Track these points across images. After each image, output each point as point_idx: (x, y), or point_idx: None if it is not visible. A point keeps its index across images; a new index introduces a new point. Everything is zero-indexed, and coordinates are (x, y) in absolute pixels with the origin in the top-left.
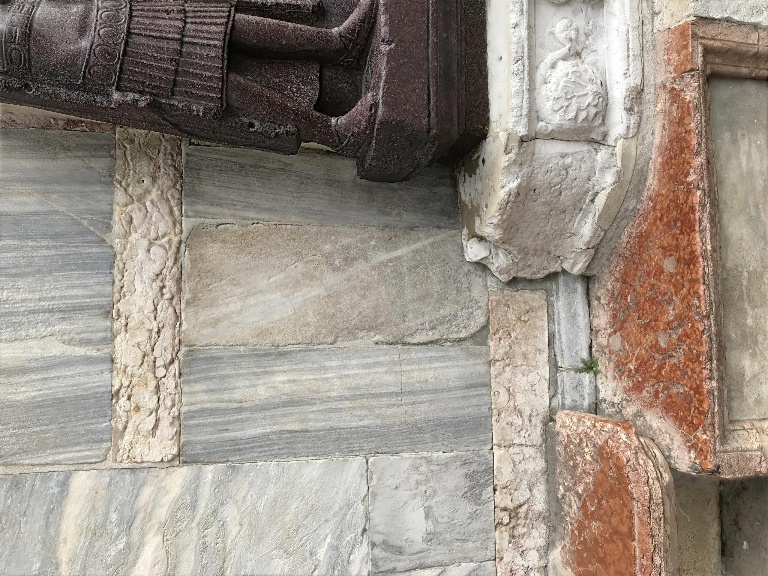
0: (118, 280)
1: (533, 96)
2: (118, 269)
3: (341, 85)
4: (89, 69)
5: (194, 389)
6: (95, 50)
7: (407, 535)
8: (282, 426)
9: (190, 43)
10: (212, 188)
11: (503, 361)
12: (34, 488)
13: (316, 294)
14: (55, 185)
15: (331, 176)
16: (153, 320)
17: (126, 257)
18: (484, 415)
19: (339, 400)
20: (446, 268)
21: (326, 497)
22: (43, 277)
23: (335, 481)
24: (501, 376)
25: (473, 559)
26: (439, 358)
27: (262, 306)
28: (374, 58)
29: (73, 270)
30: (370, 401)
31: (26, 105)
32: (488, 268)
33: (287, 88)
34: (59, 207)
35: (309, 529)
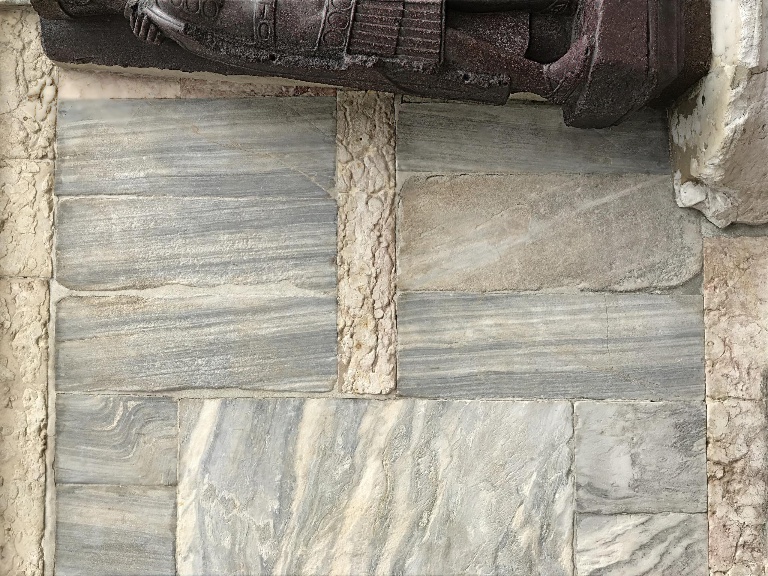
0: (341, 230)
1: (765, 24)
2: (341, 220)
3: (550, 32)
4: (324, 36)
5: (408, 330)
6: (329, 18)
7: (613, 479)
8: (489, 367)
9: (411, 3)
10: (422, 142)
11: (718, 311)
12: (275, 411)
13: (521, 242)
14: (287, 146)
15: (536, 125)
16: (371, 266)
17: (347, 209)
18: (696, 365)
19: (544, 345)
20: (656, 214)
21: (532, 437)
22: (279, 228)
23: (541, 422)
24: (716, 326)
25: (683, 509)
26: (648, 306)
27: (470, 253)
28: (588, 0)
29: (303, 221)
30: (575, 347)
31: (268, 74)
32: (702, 214)
33: (498, 39)
34: (290, 166)
35: (515, 465)
